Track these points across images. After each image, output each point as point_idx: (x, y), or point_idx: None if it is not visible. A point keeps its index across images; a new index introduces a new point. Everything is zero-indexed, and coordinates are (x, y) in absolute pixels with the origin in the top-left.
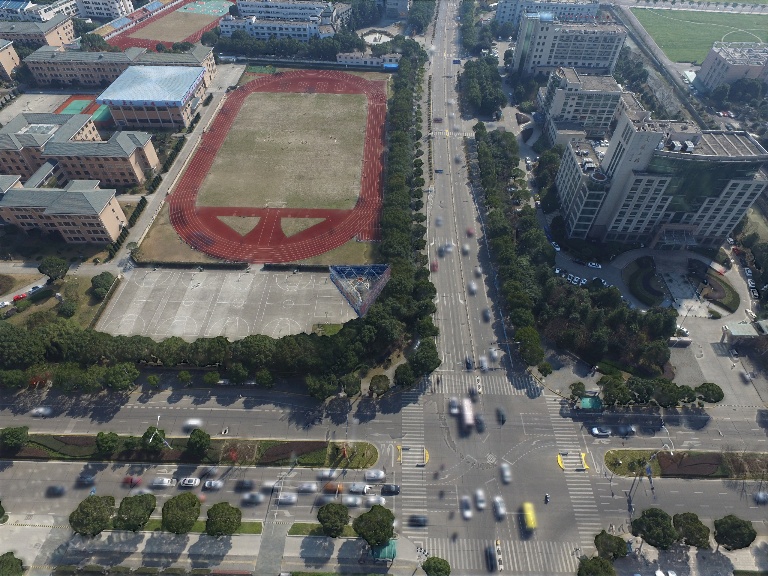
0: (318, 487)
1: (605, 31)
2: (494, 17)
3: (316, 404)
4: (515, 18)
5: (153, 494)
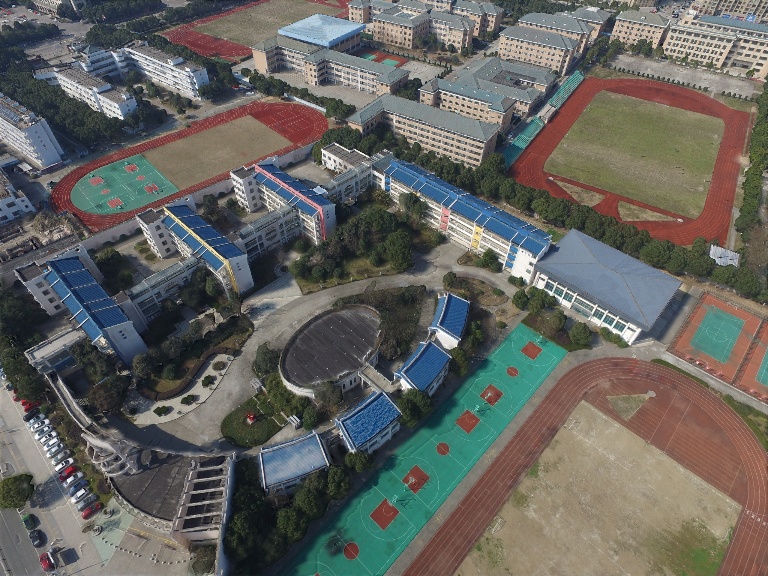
0: None
1: None
2: None
3: None
4: None
5: None
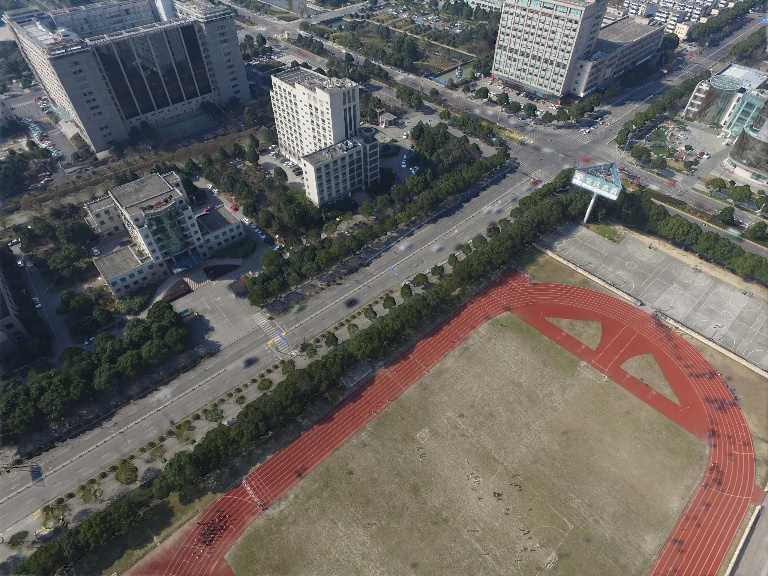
0: (656, 185)
1: None
2: None
3: None
4: None
5: None
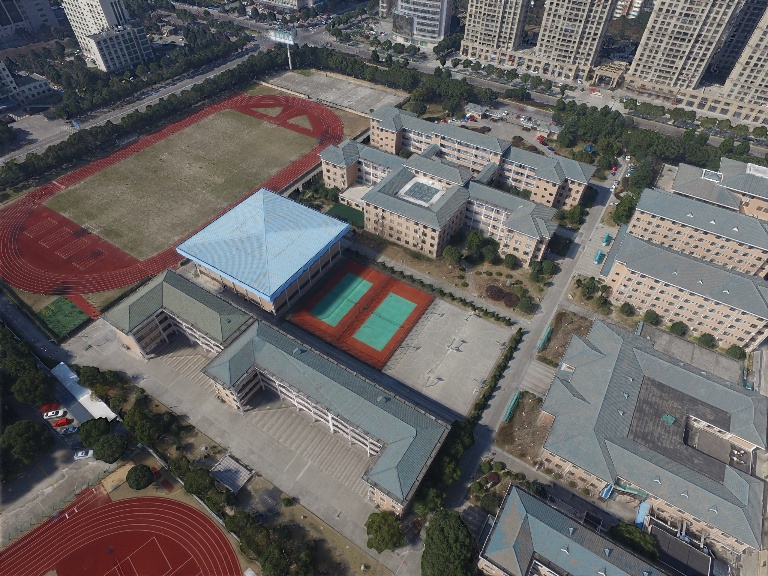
0: None
1: None
2: None
3: None
4: None
5: None
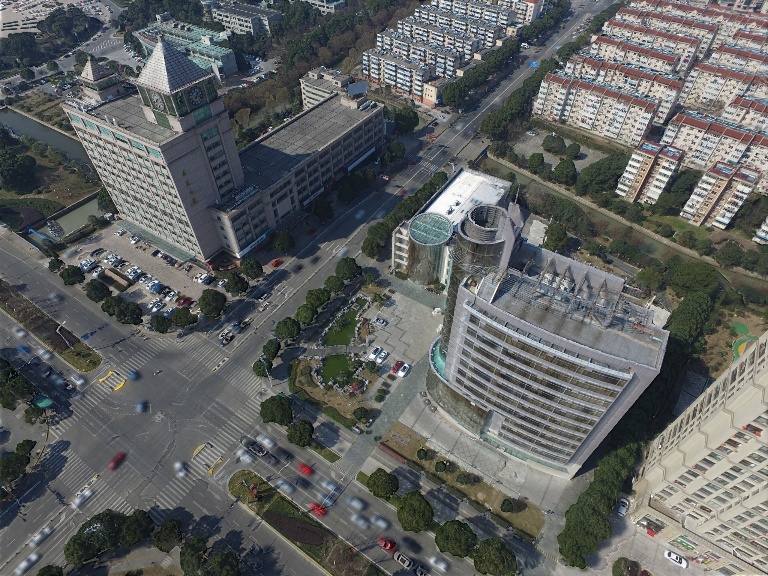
0: (297, 480)
1: None
2: None
3: (242, 575)
4: None
5: (442, 571)
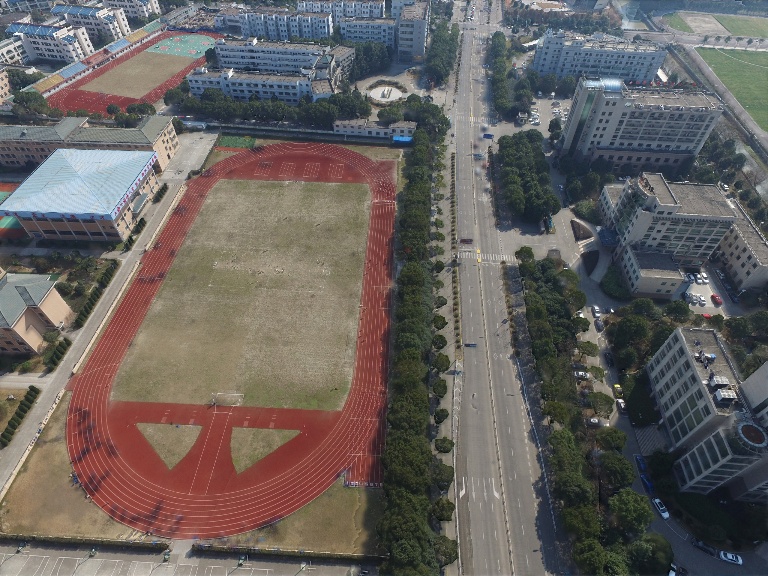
0: None
1: (693, 107)
2: (531, 63)
3: None
4: (558, 67)
5: None
